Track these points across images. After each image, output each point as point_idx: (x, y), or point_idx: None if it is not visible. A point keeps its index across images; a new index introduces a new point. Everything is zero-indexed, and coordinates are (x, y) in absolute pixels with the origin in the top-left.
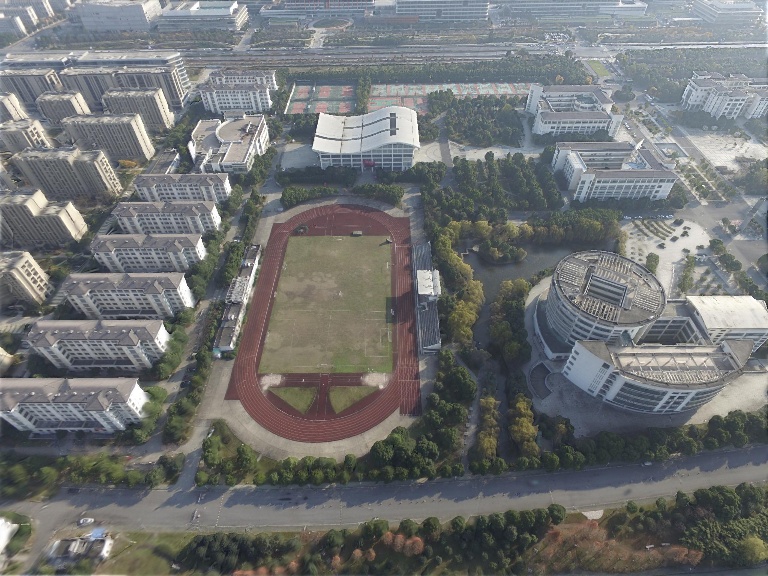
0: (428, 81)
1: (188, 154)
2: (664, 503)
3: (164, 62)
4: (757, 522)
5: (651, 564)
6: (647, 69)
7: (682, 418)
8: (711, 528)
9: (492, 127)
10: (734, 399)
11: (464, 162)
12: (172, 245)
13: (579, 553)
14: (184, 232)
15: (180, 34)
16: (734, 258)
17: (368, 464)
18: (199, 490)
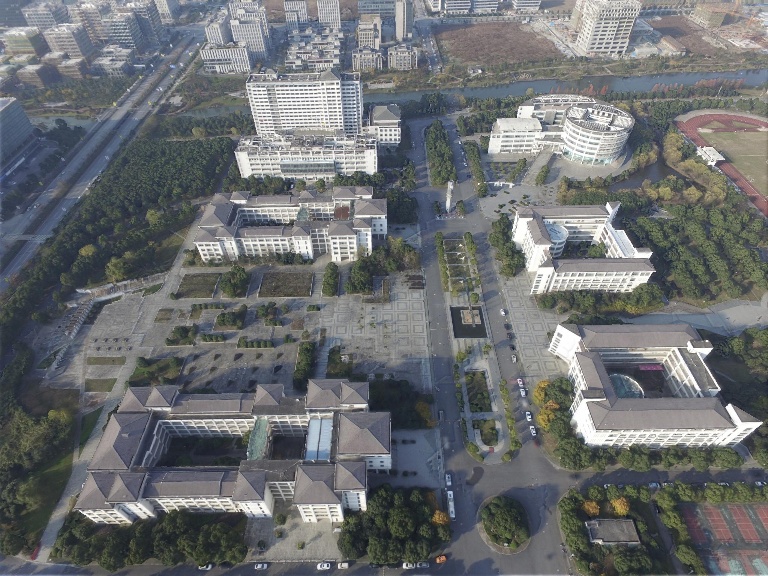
0: None
1: None
2: None
3: None
4: None
5: None
6: None
7: None
8: None
9: (767, 353)
10: None
11: None
12: None
13: None
14: None
15: None
16: None
17: None
18: None
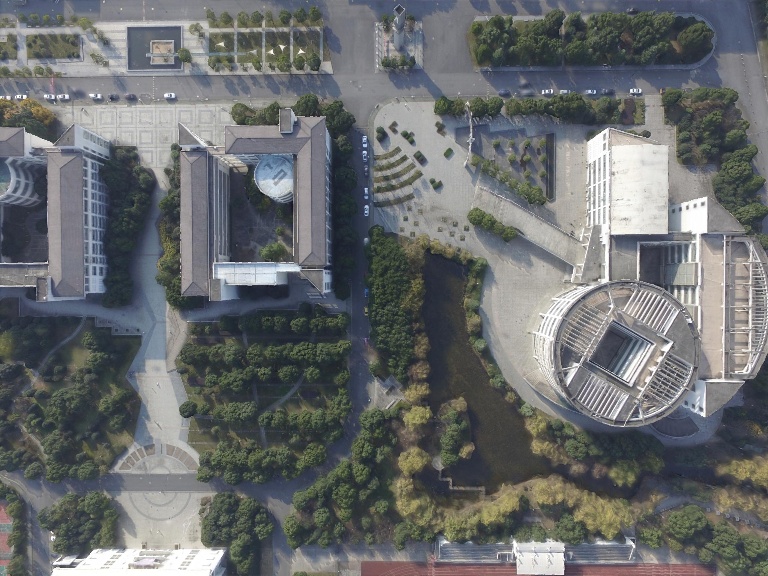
0: None
1: None
2: None
3: None
4: None
5: None
6: None
7: None
8: None
9: (80, 390)
10: None
11: None
12: None
13: None
14: None
15: None
16: None
17: None
18: None
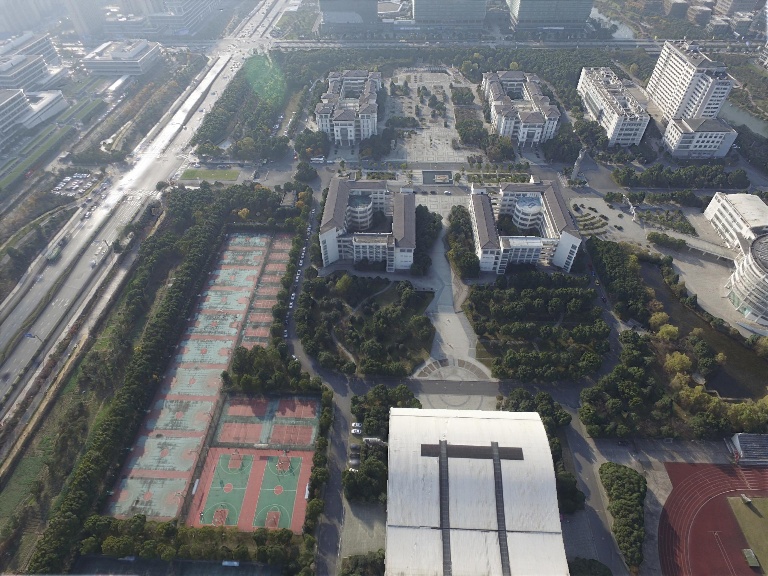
0: (158, 385)
1: None
2: None
3: None
4: None
5: None
6: None
7: None
8: None
9: None
10: None
11: (516, 361)
12: None
13: None
14: None
15: None
16: None
17: None
18: None
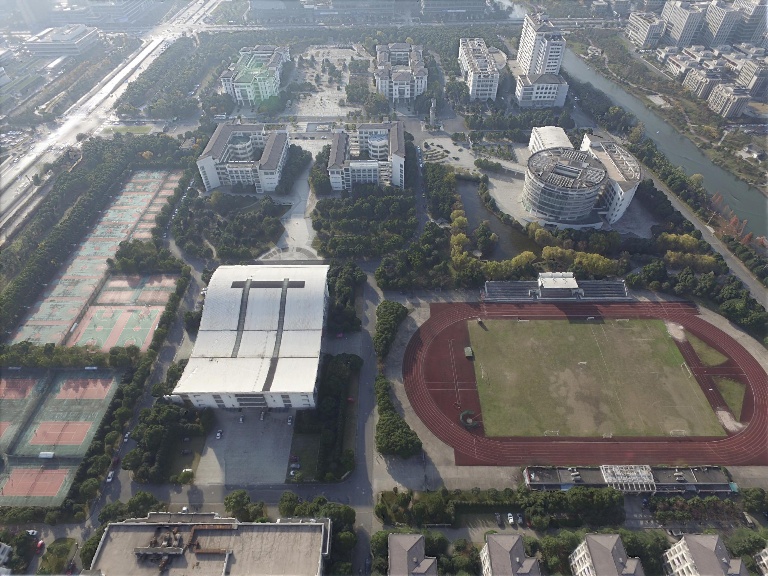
0: (56, 269)
1: None
2: None
3: None
4: None
5: None
6: None
7: None
8: None
9: None
10: None
11: (335, 242)
12: None
13: (737, 239)
14: None
15: None
16: None
17: (759, 334)
18: None
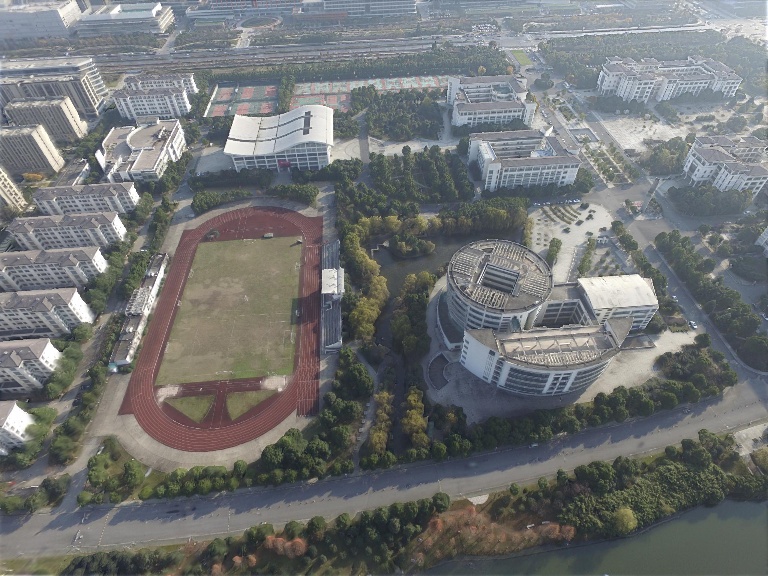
0: (353, 77)
1: (98, 164)
2: (544, 482)
3: (75, 69)
4: (630, 493)
5: (527, 543)
6: (567, 57)
7: (571, 398)
8: (586, 503)
9: (411, 121)
10: (622, 375)
11: (380, 158)
12: (66, 260)
13: (462, 539)
14: (87, 245)
15: (101, 39)
16: (632, 238)
17: (260, 469)
18: (83, 510)
